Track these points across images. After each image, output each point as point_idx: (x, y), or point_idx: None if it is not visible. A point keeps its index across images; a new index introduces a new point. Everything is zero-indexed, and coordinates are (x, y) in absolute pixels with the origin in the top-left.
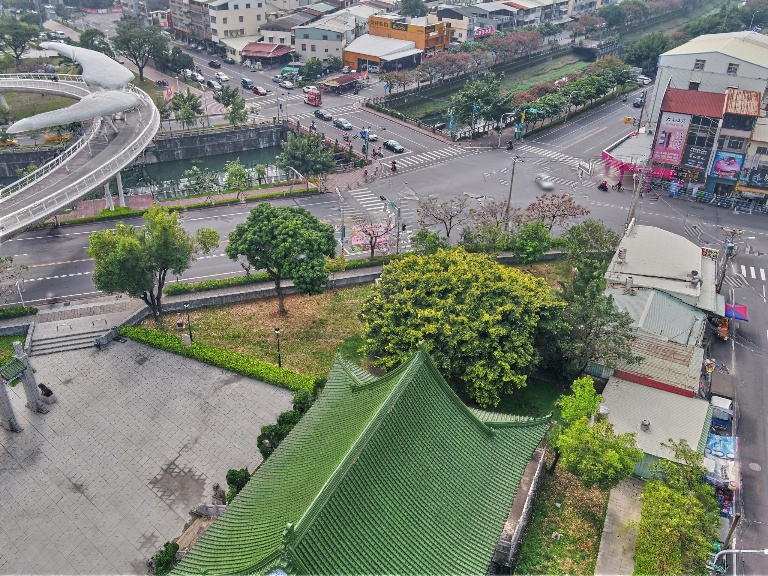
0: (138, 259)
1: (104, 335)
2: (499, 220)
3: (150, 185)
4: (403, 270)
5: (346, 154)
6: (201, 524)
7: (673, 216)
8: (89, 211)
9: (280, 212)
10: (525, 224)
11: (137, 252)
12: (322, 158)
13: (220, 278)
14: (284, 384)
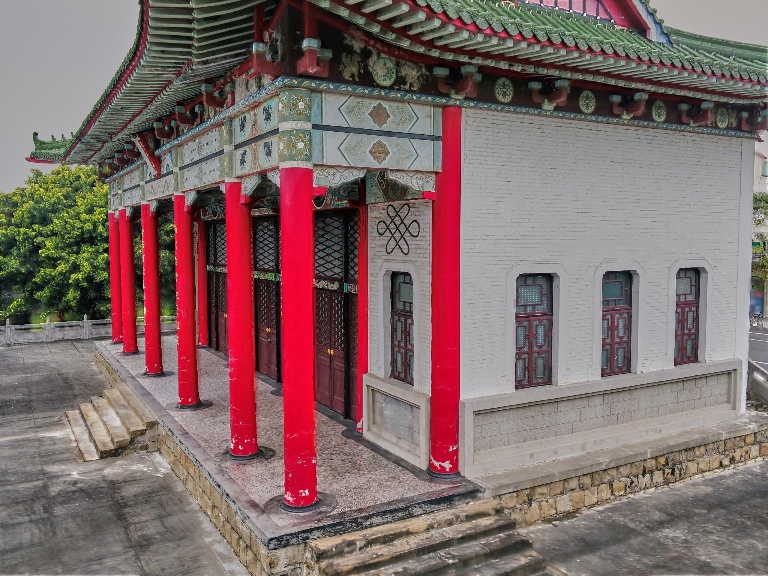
0: None
1: None
2: None
3: None
4: None
5: None
6: None
7: None
8: None
9: None
10: None
11: None
12: None
13: None
14: None
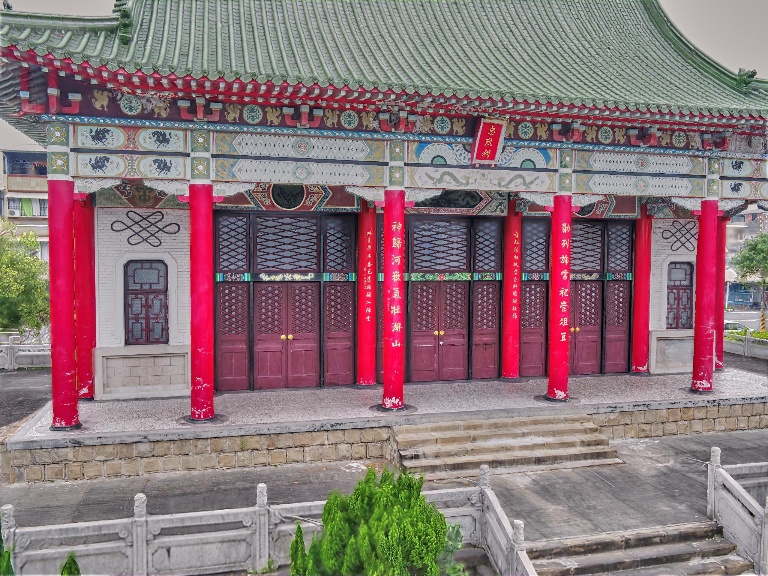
0: None
1: None
2: None
3: None
4: None
5: None
6: None
7: None
8: None
9: None
10: None
11: None
12: None
13: None
14: None
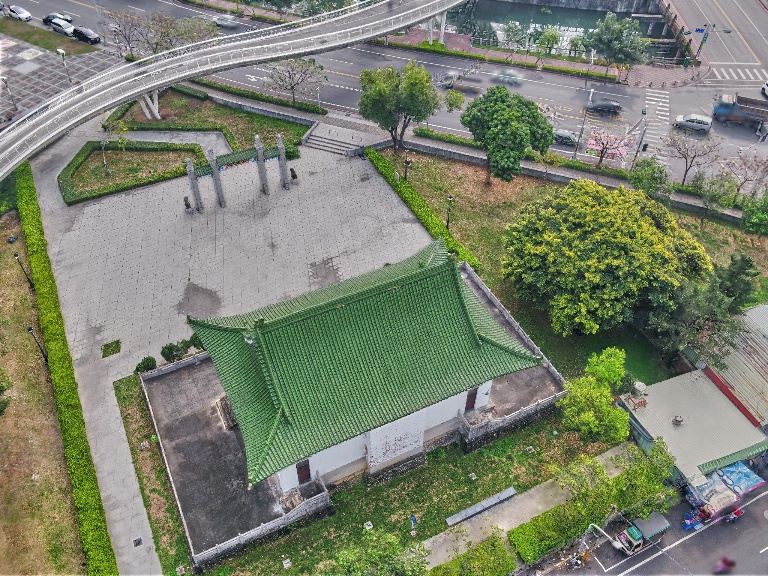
0: (387, 101)
1: (352, 149)
2: (749, 177)
3: (474, 28)
4: None
5: (672, 48)
6: None
7: None
8: (415, 39)
9: (510, 99)
10: (767, 192)
11: (387, 95)
12: (628, 48)
13: (463, 135)
14: None
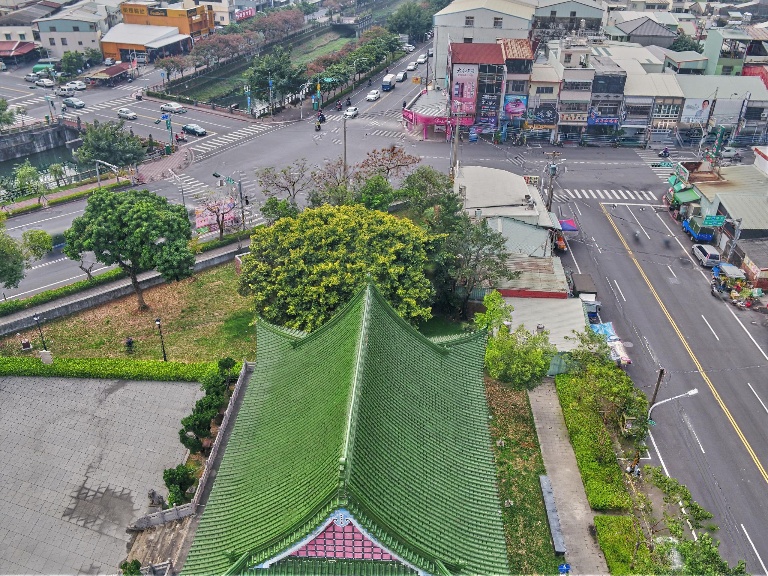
0: None
1: None
2: (339, 180)
3: None
4: (275, 235)
5: (150, 142)
6: (147, 538)
7: (494, 152)
8: None
9: (123, 197)
10: (367, 179)
11: None
12: (131, 146)
13: (55, 288)
14: (179, 377)
